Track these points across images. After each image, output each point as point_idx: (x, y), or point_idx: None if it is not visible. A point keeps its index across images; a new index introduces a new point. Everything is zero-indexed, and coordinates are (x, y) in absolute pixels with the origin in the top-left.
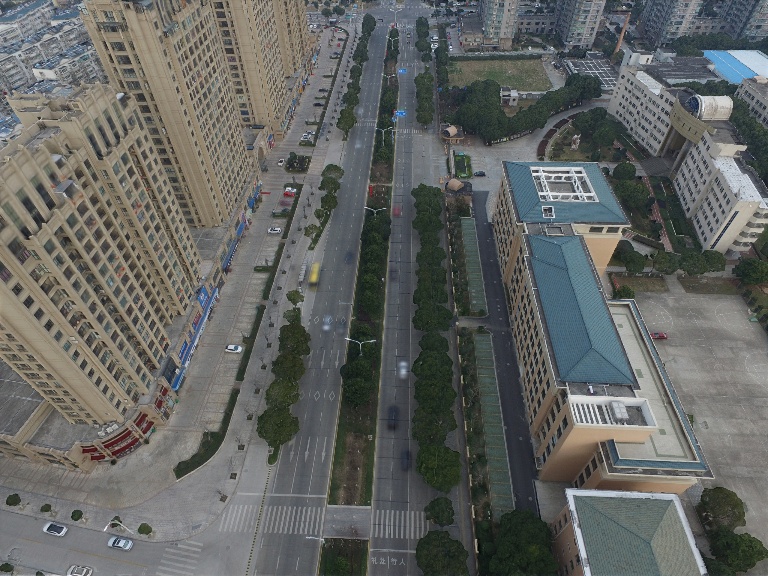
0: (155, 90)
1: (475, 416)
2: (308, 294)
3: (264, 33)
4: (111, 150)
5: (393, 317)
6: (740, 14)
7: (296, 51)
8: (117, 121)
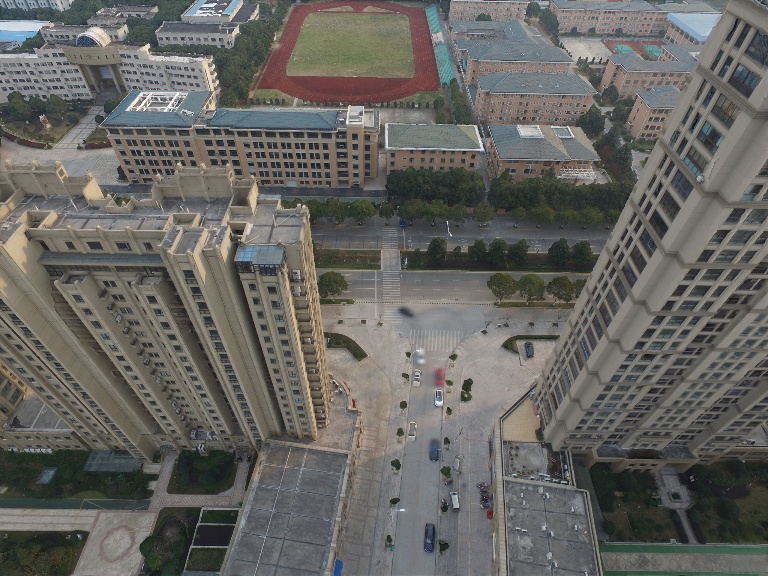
0: None
1: None
2: None
3: None
4: None
5: None
6: None
7: None
8: None
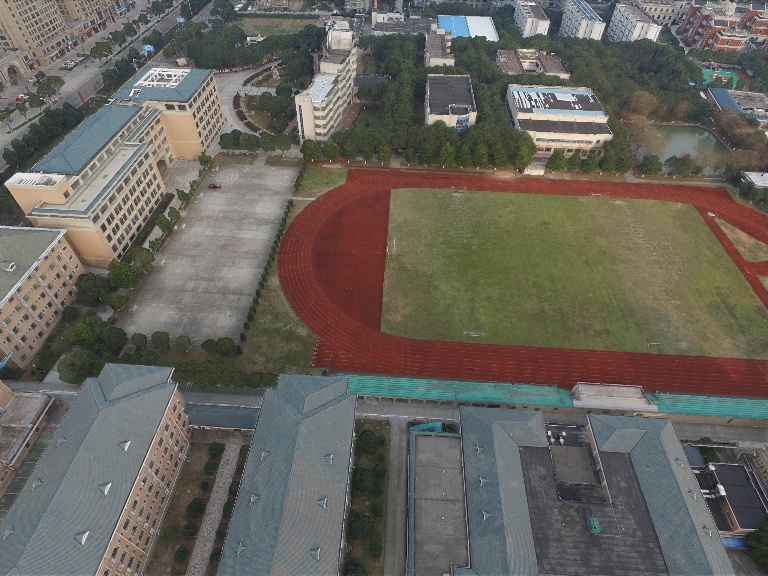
0: None
1: None
2: None
3: None
4: None
5: None
6: None
7: None
8: None
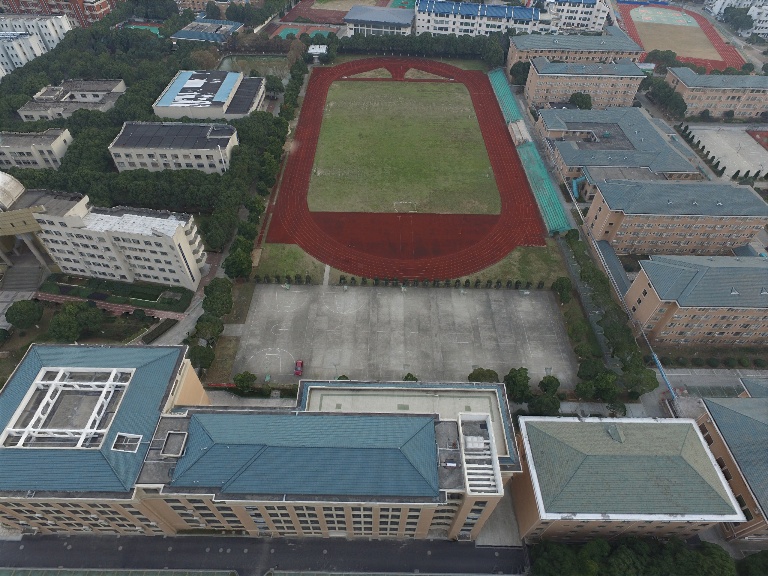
0: None
1: None
2: None
3: None
4: None
5: None
6: None
7: None
8: None
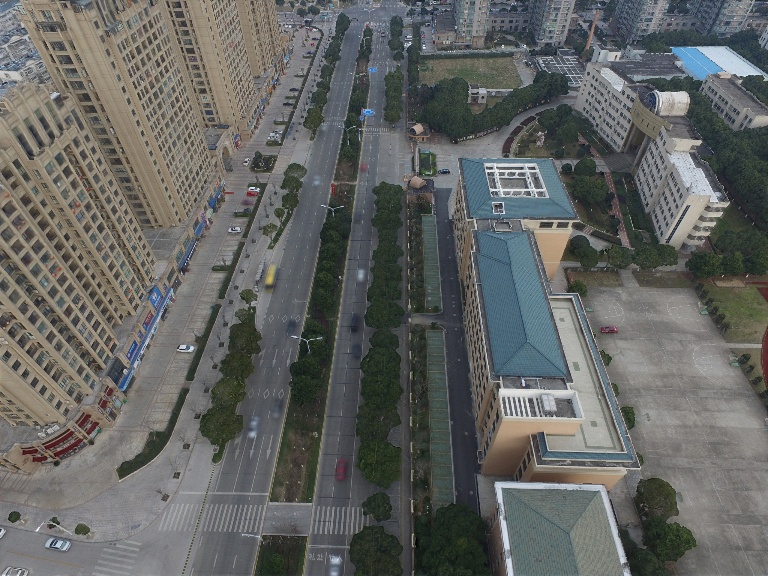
0: (100, 90)
1: (422, 412)
2: (264, 293)
3: (226, 33)
4: (43, 150)
5: (348, 315)
6: (710, 11)
7: (265, 51)
8: (51, 121)
